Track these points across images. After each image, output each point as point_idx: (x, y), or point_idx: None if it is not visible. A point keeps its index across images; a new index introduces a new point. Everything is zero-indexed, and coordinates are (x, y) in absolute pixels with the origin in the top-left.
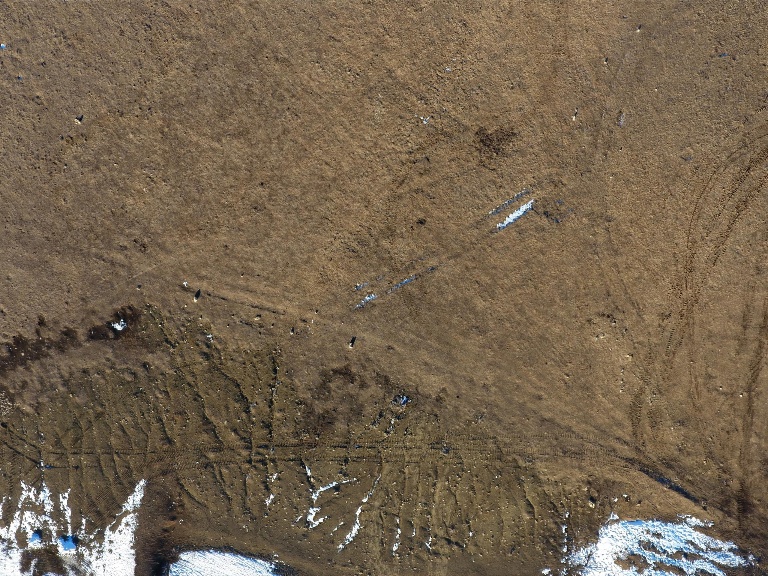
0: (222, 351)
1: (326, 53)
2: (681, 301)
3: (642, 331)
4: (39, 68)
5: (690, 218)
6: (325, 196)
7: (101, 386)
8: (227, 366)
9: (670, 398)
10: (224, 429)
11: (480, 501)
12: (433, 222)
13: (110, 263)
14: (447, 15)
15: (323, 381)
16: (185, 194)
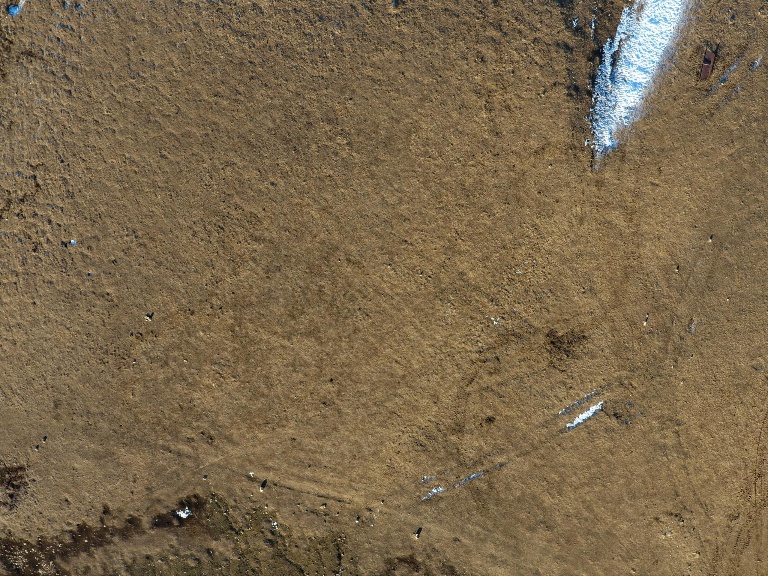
0: (287, 538)
1: (398, 256)
2: (750, 504)
3: (710, 530)
4: (110, 266)
5: (760, 426)
6: (394, 392)
7: (164, 572)
8: (291, 552)
9: None
10: None
11: None
12: (502, 420)
13: (177, 454)
14: (519, 220)
15: (388, 569)
16: (254, 389)
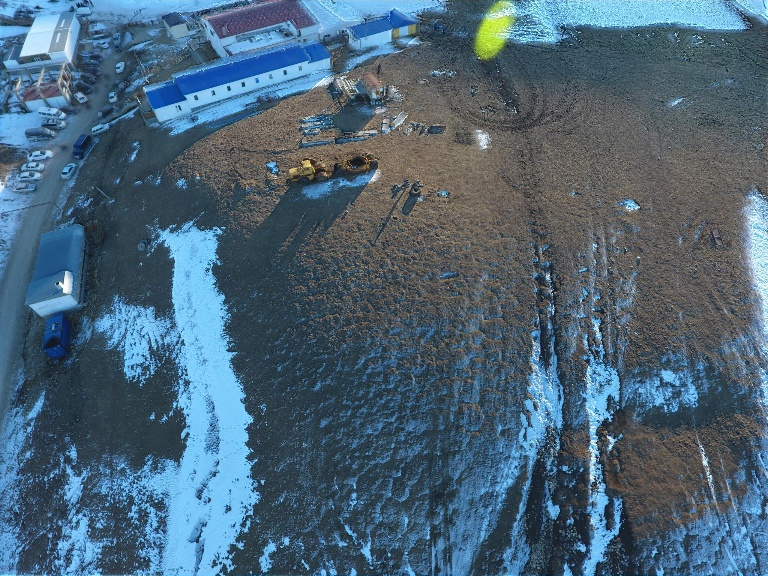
0: None
1: None
2: None
3: None
4: None
5: None
6: None
7: None
8: None
9: None
10: (766, 51)
11: None
12: None
13: None
14: None
15: None
16: None
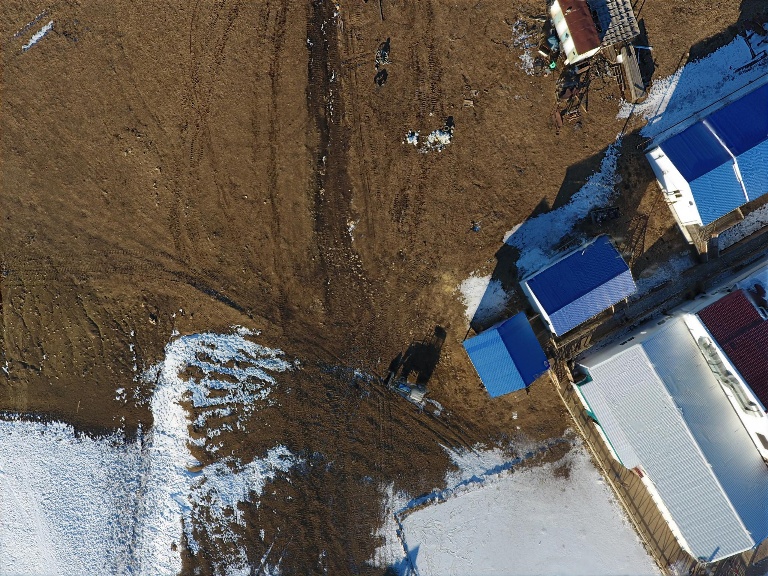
0: None
1: None
2: (194, 111)
3: (165, 143)
4: None
5: (189, 29)
6: None
7: None
8: None
9: (203, 209)
10: None
11: (46, 322)
12: None
13: None
14: None
15: None
16: None
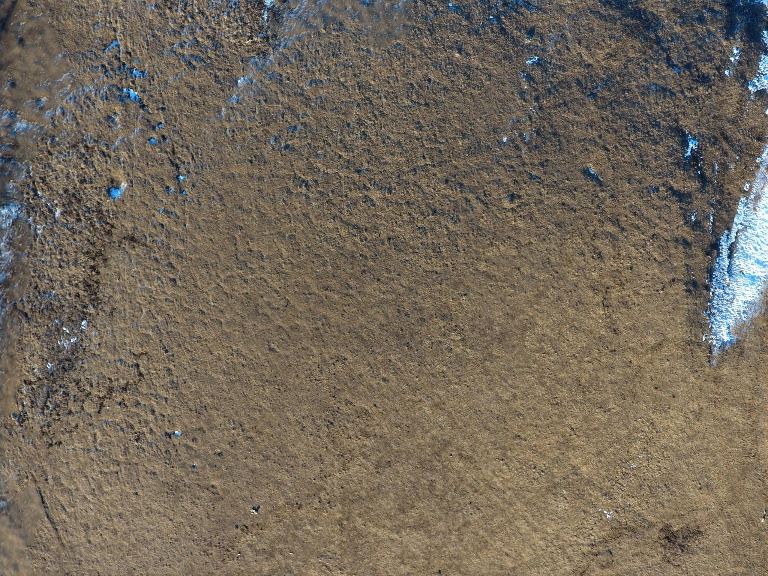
0: None
1: (511, 451)
2: None
3: None
4: (215, 459)
5: None
6: None
7: None
8: None
9: None
10: None
11: None
12: None
13: None
14: (635, 415)
15: None
16: None
